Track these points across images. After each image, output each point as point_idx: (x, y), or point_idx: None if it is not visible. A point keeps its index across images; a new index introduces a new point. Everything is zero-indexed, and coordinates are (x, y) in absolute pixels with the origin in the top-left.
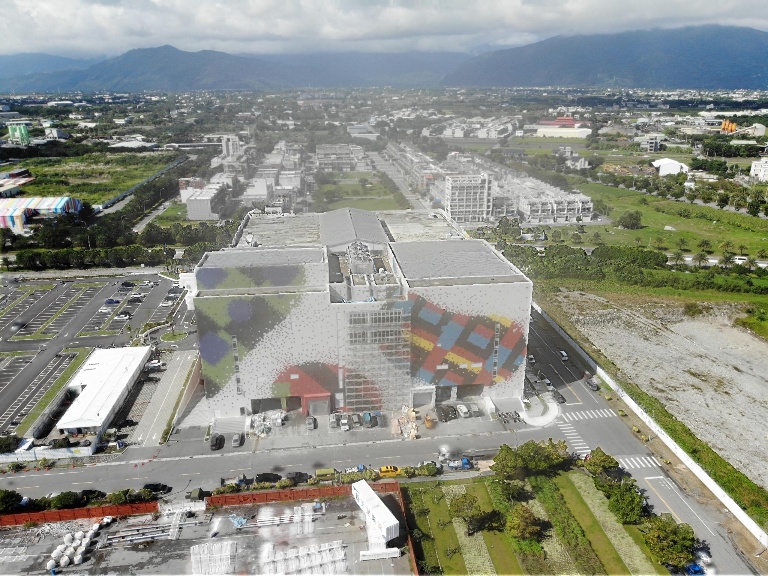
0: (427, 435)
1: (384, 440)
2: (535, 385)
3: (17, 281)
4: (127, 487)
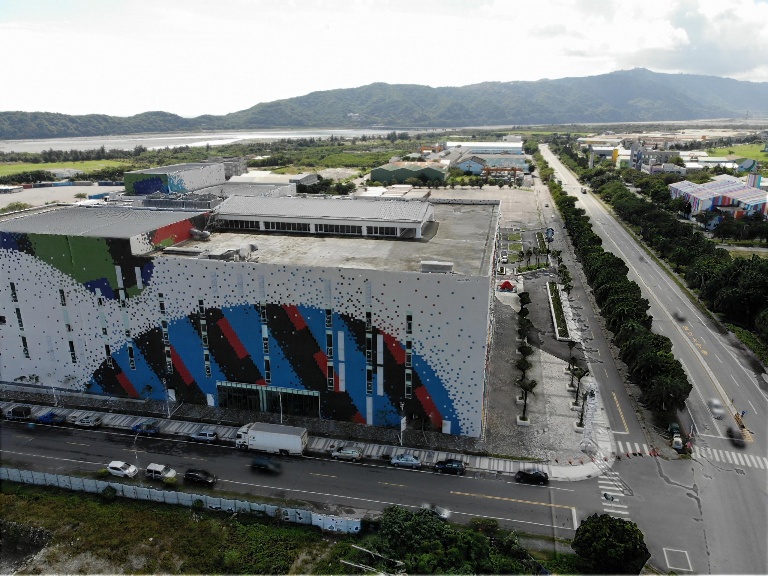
0: None
1: None
2: None
3: (536, 232)
4: None
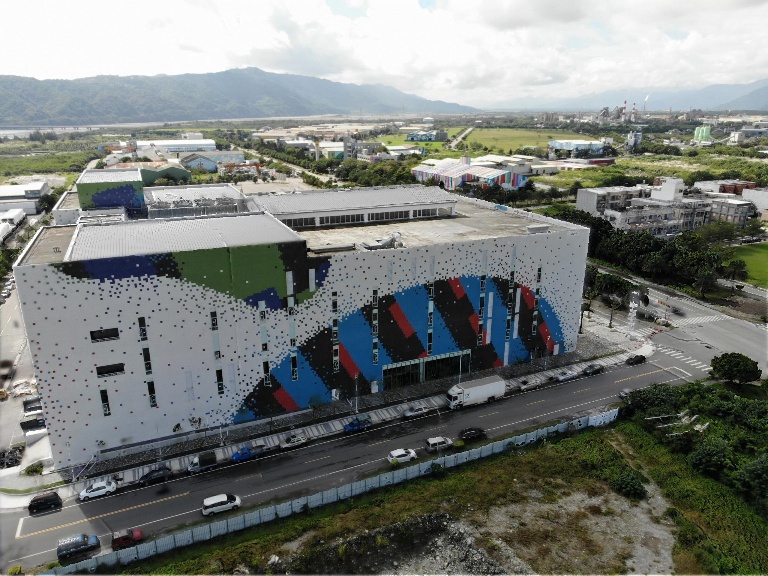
0: (4, 404)
1: (10, 382)
2: (105, 477)
3: None
4: (6, 307)
